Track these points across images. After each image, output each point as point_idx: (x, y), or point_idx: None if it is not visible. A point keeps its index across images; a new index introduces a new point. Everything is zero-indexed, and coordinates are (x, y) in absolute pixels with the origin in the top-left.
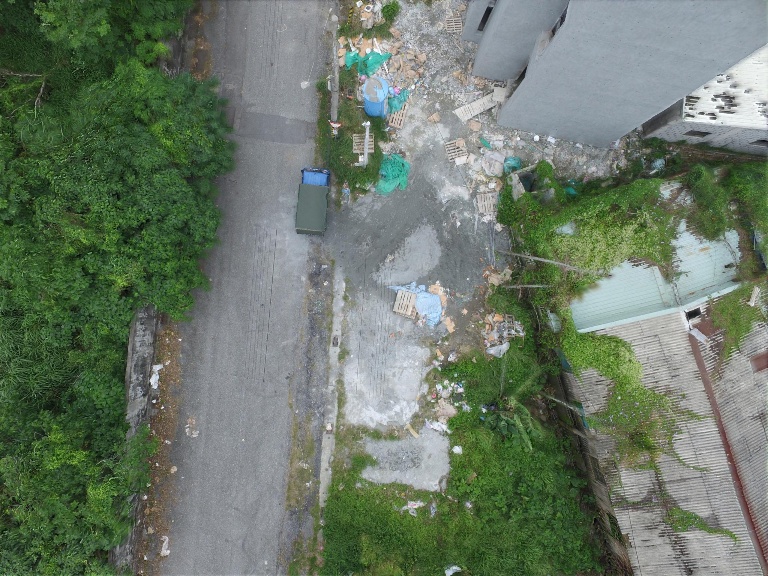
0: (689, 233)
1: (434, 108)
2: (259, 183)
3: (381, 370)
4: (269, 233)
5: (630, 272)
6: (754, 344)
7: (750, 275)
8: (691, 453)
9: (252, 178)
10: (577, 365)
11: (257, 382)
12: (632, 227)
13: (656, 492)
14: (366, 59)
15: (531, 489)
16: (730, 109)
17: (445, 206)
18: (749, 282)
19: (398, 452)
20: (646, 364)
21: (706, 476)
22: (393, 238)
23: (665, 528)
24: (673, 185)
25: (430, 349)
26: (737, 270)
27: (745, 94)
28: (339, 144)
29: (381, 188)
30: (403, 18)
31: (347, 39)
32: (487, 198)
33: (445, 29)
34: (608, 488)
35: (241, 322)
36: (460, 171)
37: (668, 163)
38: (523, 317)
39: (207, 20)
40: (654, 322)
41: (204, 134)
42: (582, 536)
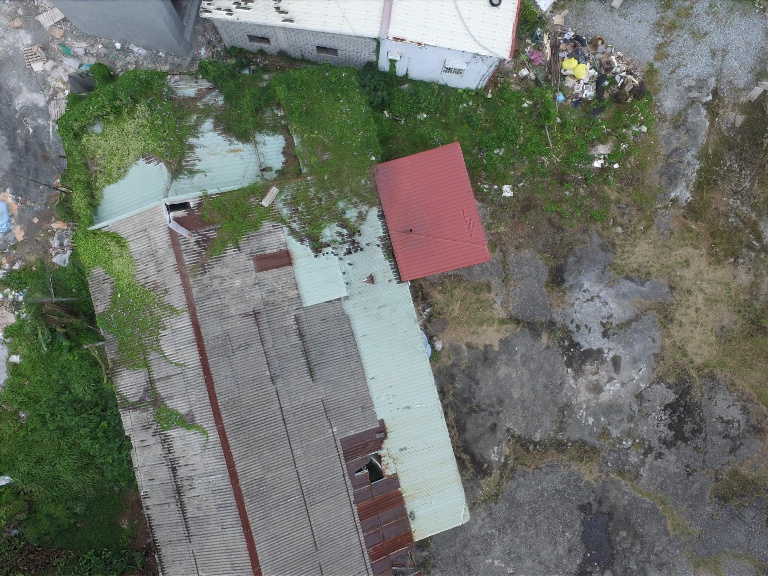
0: (217, 134)
1: (16, 13)
2: None
3: None
4: None
5: (144, 170)
6: (263, 244)
7: None
8: (173, 349)
9: None
10: (86, 263)
11: None
12: (136, 122)
13: (149, 390)
14: None
15: (72, 396)
16: (247, 5)
17: (18, 112)
18: (265, 182)
19: None
20: (139, 260)
21: (185, 372)
22: None
23: (157, 427)
24: (202, 85)
25: None
26: (262, 172)
27: None
28: None
29: None
30: None
31: None
32: (60, 105)
33: None
34: (113, 388)
35: None
36: (37, 77)
37: None
38: None
39: None
40: (144, 216)
41: None
42: None
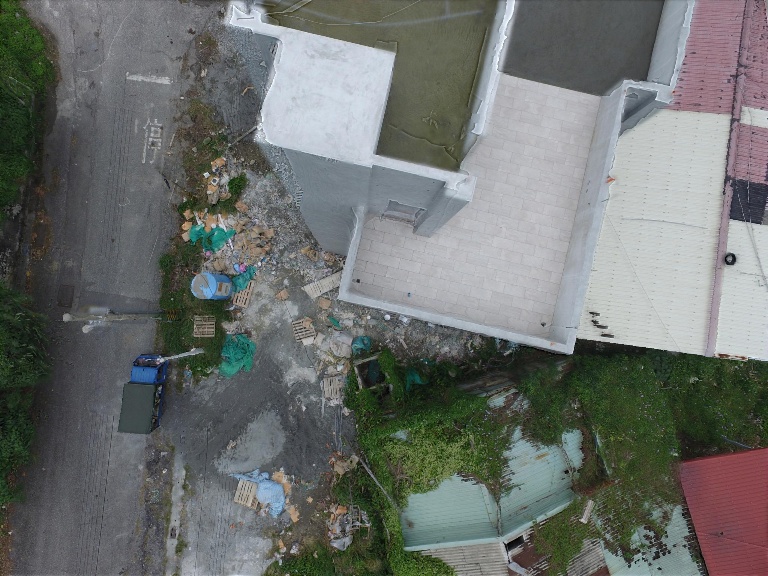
0: (525, 441)
1: (282, 284)
2: (96, 366)
3: (220, 564)
4: (105, 419)
5: (459, 486)
6: (586, 565)
7: (592, 480)
8: None
9: (89, 361)
10: None
11: None
12: (458, 444)
13: None
14: (212, 234)
15: None
16: None
17: (290, 389)
18: (583, 498)
19: None
20: None
21: None
22: (236, 423)
23: None
24: (509, 390)
25: (272, 540)
26: (573, 481)
27: None
28: (181, 325)
29: (224, 370)
30: (251, 190)
31: (193, 212)
32: (333, 382)
33: (295, 202)
34: None
35: (74, 514)
36: (307, 352)
37: None
38: (366, 510)
39: (48, 193)
40: (475, 550)
41: (4, 355)
42: None
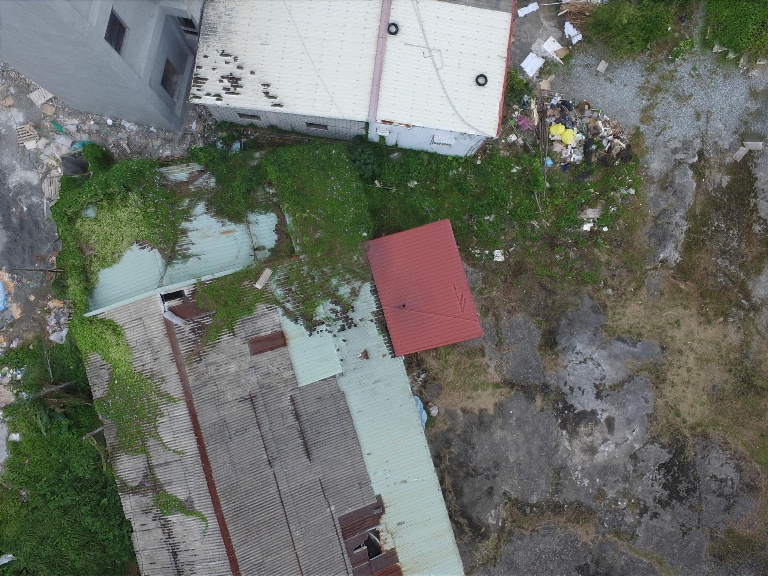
0: (209, 216)
1: (8, 92)
2: None
3: None
4: None
5: (138, 255)
6: (258, 327)
7: None
8: (171, 436)
9: None
10: (83, 349)
11: None
12: (129, 209)
13: (148, 476)
14: None
15: (72, 475)
16: (236, 90)
17: (12, 191)
18: (258, 265)
19: None
20: (135, 347)
21: (183, 459)
22: None
23: (156, 512)
24: (194, 168)
25: None
26: (255, 253)
27: (251, 75)
28: None
29: None
30: None
31: None
32: (53, 183)
33: None
34: (113, 473)
35: None
36: (30, 156)
37: (245, 147)
38: None
39: None
40: (139, 305)
41: None
42: None
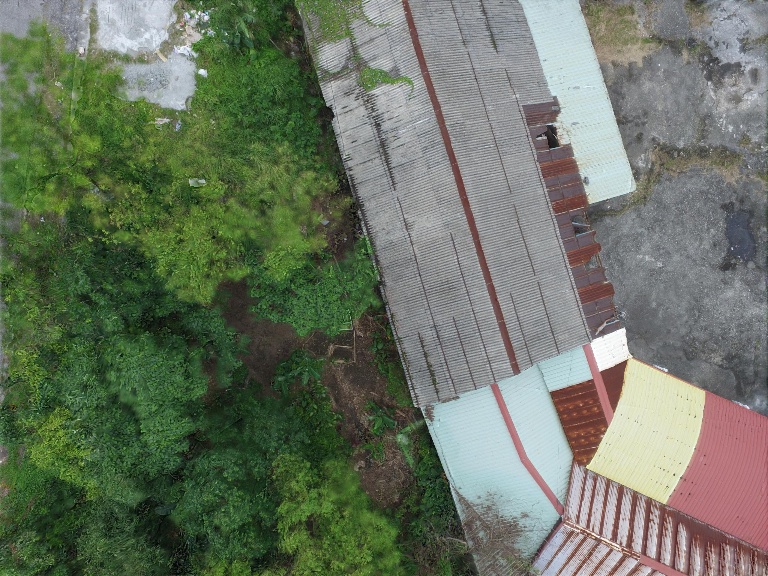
0: None
1: None
2: None
3: None
4: None
5: None
6: None
7: None
8: (377, 12)
9: None
10: None
11: (12, 6)
12: None
13: (351, 58)
14: None
15: (263, 95)
16: None
17: None
18: None
19: (147, 74)
20: None
21: (389, 31)
22: None
23: (359, 91)
24: None
25: None
26: None
27: None
28: None
29: None
30: None
31: None
32: None
33: None
34: (314, 65)
35: None
36: None
37: None
38: None
39: None
40: None
41: None
42: (322, 156)
